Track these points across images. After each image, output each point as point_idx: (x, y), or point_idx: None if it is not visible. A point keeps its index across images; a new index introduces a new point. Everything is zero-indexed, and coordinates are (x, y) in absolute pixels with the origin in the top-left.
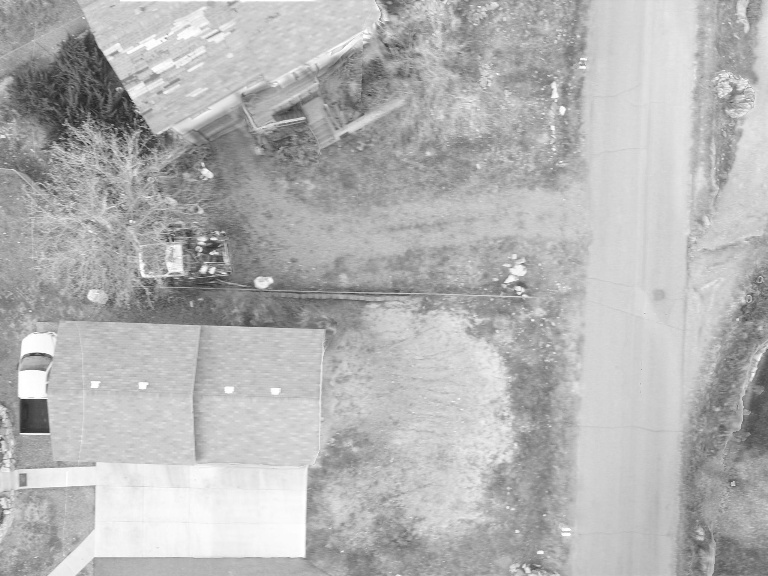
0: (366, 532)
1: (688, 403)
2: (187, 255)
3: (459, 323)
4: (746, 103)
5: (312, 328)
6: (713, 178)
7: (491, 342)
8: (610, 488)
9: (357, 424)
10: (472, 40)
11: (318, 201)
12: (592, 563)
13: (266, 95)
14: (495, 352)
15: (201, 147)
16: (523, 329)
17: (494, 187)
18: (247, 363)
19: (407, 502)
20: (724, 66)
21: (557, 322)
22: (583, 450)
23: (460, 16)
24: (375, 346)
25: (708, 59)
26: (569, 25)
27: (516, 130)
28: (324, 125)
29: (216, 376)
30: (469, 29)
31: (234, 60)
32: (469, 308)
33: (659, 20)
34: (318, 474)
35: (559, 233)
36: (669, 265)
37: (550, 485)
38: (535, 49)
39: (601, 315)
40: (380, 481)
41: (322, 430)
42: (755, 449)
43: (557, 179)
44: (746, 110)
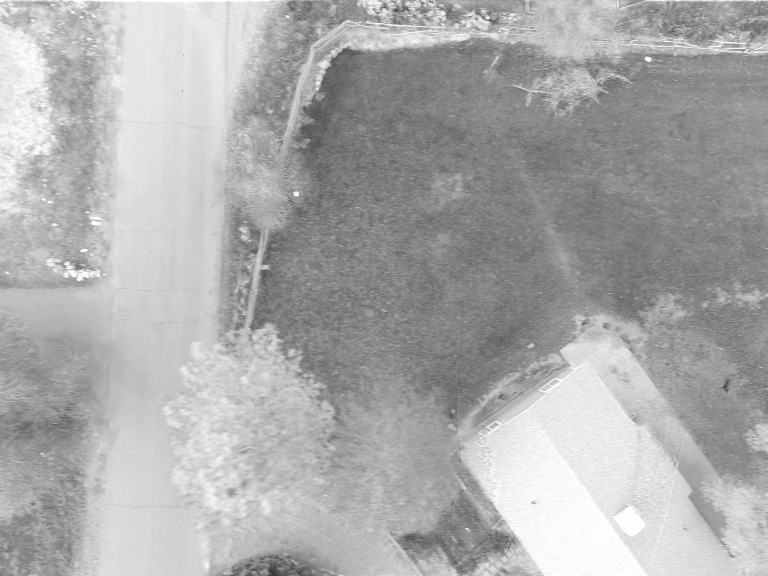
0: None
1: (232, 99)
2: None
3: None
4: None
5: None
6: None
7: (28, 32)
8: (152, 185)
9: None
10: None
11: None
12: (133, 260)
13: None
14: (32, 42)
15: None
16: (64, 21)
17: None
18: None
19: None
20: None
21: (97, 14)
22: (124, 145)
23: None
24: None
25: None
26: None
27: None
28: None
29: None
30: None
31: None
32: None
33: None
34: None
35: None
36: None
37: (92, 181)
38: None
39: (141, 7)
40: None
41: None
42: (321, 160)
43: None
44: None
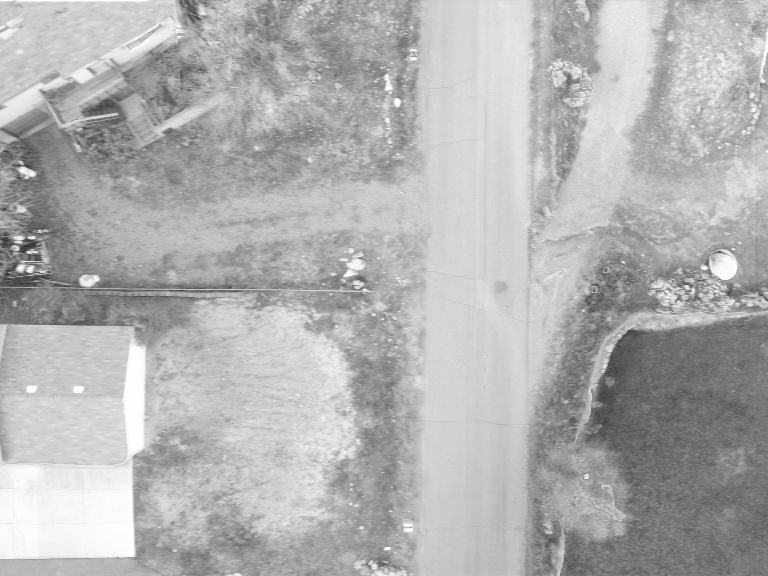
0: (199, 531)
1: (533, 396)
2: (2, 254)
3: (297, 319)
4: (581, 92)
5: (120, 325)
6: (554, 168)
7: (331, 337)
8: (456, 483)
9: (184, 422)
10: (298, 33)
11: (144, 198)
12: (439, 559)
13: (67, 91)
14: (335, 347)
15: (12, 145)
16: (364, 324)
17: (327, 181)
18: (52, 362)
19: (243, 500)
20: (563, 55)
21: (398, 316)
22: (427, 445)
23: (284, 9)
24: (204, 343)
25: (544, 48)
26: (402, 16)
27: (349, 123)
28: (144, 121)
29: (20, 375)
30: (294, 22)
31: (25, 56)
32: (307, 303)
33: (493, 10)
34: (143, 473)
35: (397, 226)
36: (510, 257)
37: (395, 481)
38: (366, 41)
39: (442, 308)
40: (212, 479)
41: (146, 428)
42: (609, 441)
43: (394, 172)
44: (581, 99)
